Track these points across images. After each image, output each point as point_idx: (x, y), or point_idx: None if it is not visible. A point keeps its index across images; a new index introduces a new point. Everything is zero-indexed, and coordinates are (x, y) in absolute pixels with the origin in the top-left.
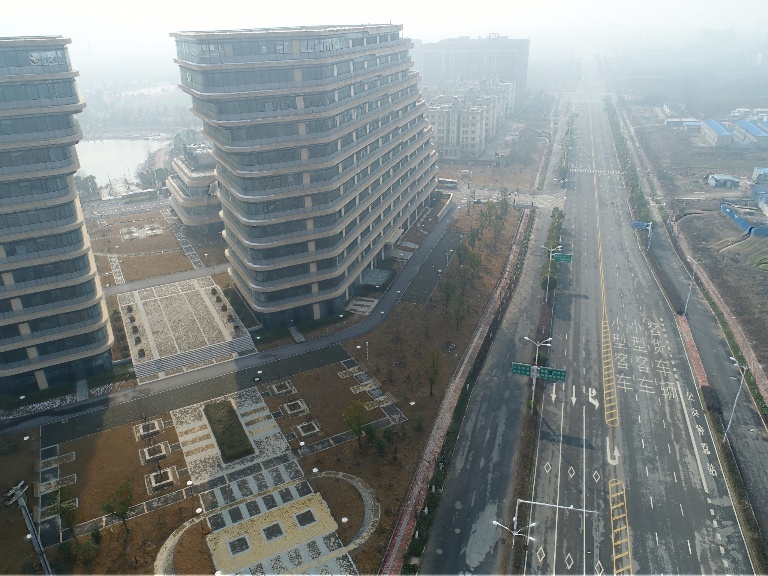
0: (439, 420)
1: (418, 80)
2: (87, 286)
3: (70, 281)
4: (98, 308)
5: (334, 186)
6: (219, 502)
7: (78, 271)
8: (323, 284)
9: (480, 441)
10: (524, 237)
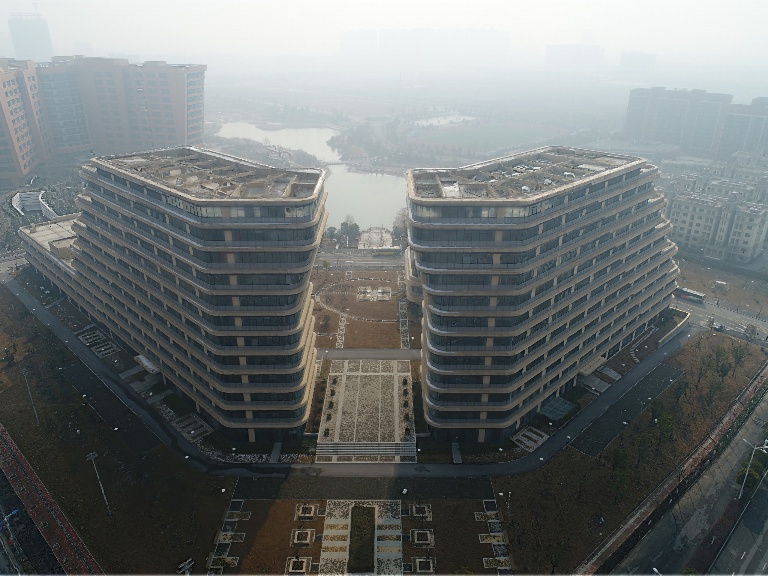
0: None
1: None
2: (295, 375)
3: (283, 371)
4: (301, 391)
5: (518, 332)
6: None
7: (291, 364)
8: (492, 413)
9: None
10: (753, 397)
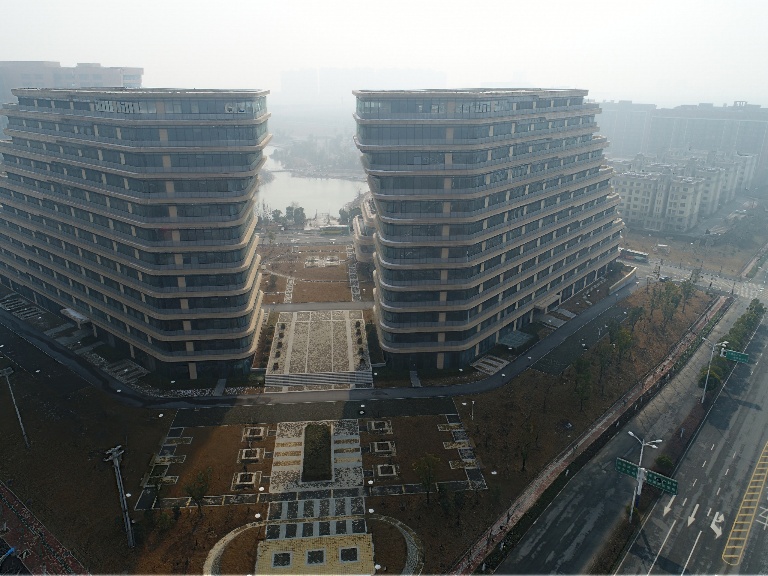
0: (522, 499)
1: (604, 146)
2: (240, 299)
3: (226, 292)
4: (247, 319)
5: (473, 241)
6: (282, 515)
7: (235, 285)
8: (450, 335)
9: (558, 533)
10: (704, 326)
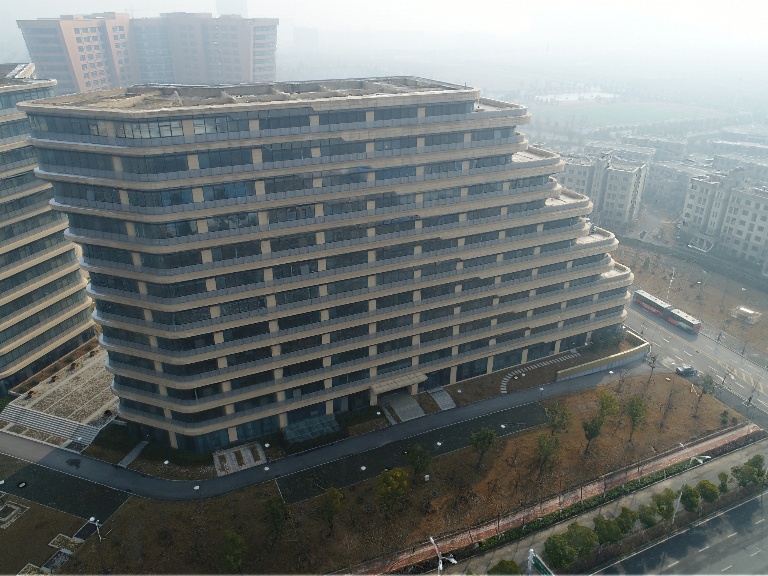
0: None
1: (543, 171)
2: None
3: None
4: None
5: (174, 308)
6: None
7: None
8: (177, 413)
9: None
10: None
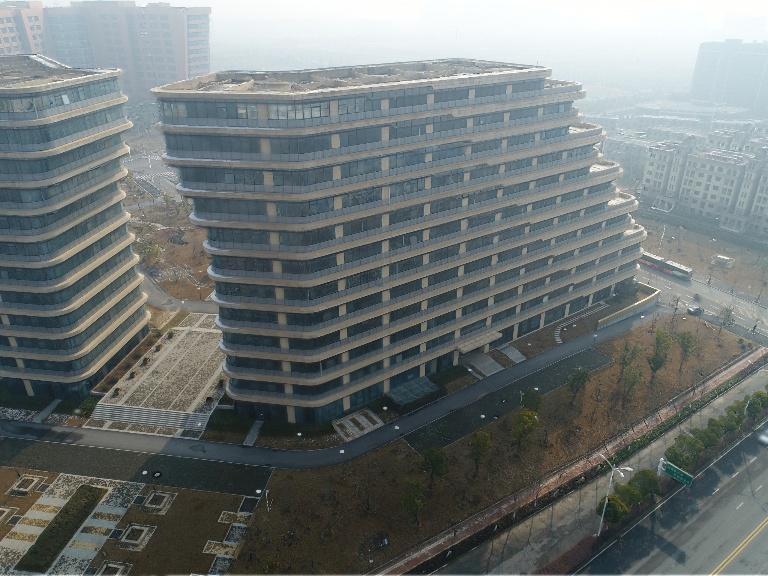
0: None
1: (592, 141)
2: (63, 319)
3: (41, 313)
4: (78, 340)
5: (312, 283)
6: None
7: (51, 305)
8: (299, 387)
9: None
10: None
